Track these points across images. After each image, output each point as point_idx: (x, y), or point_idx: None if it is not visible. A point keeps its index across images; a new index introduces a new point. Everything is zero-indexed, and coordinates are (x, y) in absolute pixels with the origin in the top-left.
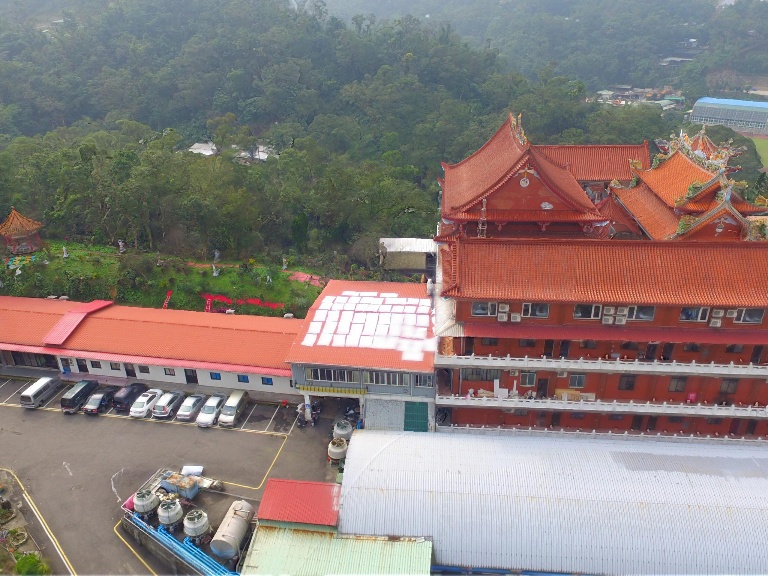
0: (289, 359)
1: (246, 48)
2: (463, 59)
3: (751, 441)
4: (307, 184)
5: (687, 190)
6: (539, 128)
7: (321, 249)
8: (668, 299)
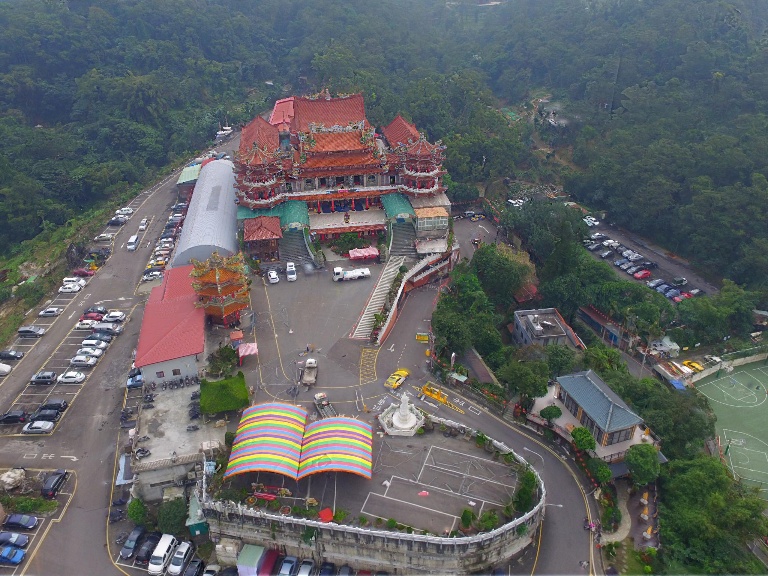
0: None
1: None
2: None
3: None
4: None
5: None
6: (698, 167)
7: None
8: None
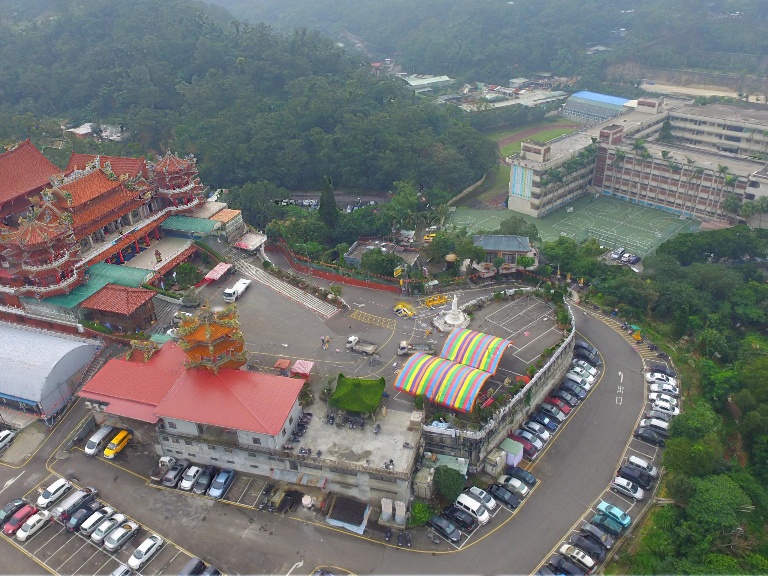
0: None
1: (133, 50)
2: (286, 62)
3: (13, 324)
4: None
5: None
6: (299, 125)
7: None
8: None
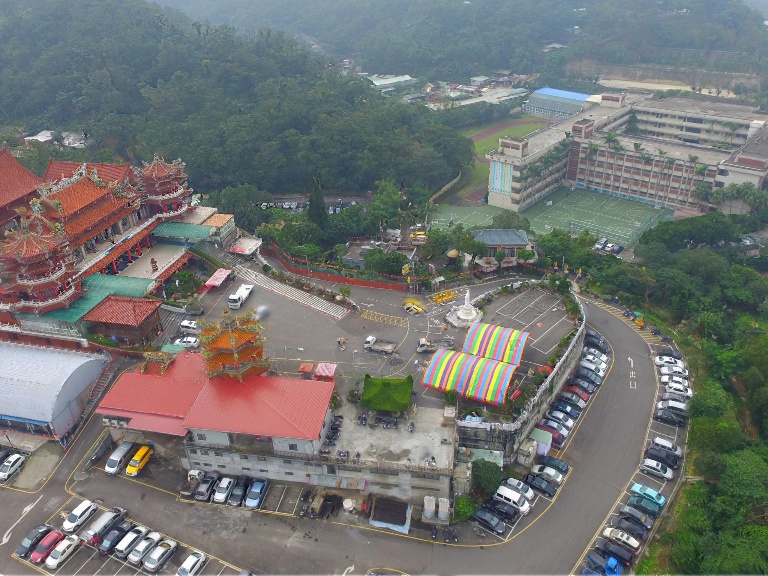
0: None
1: None
2: (254, 64)
3: (6, 343)
4: (41, 172)
5: None
6: (273, 127)
7: None
8: None
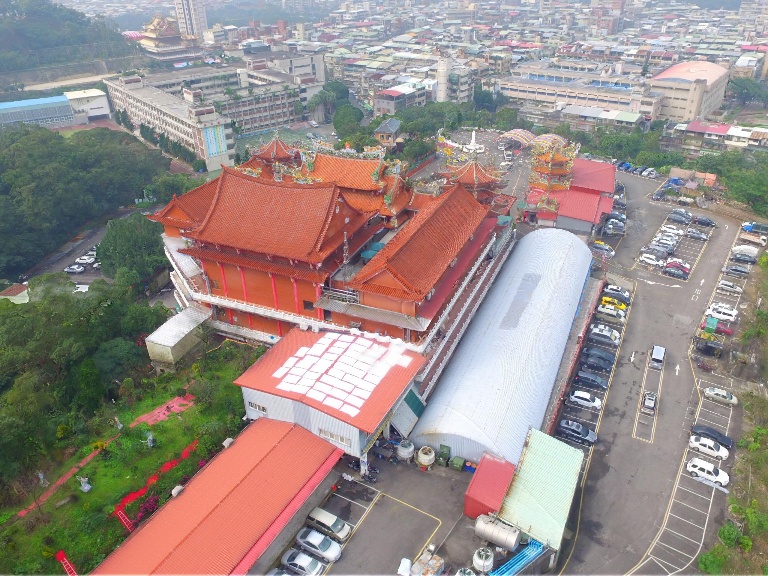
0: (371, 429)
1: None
2: None
3: None
4: None
5: (371, 176)
6: None
7: (65, 400)
8: (467, 235)
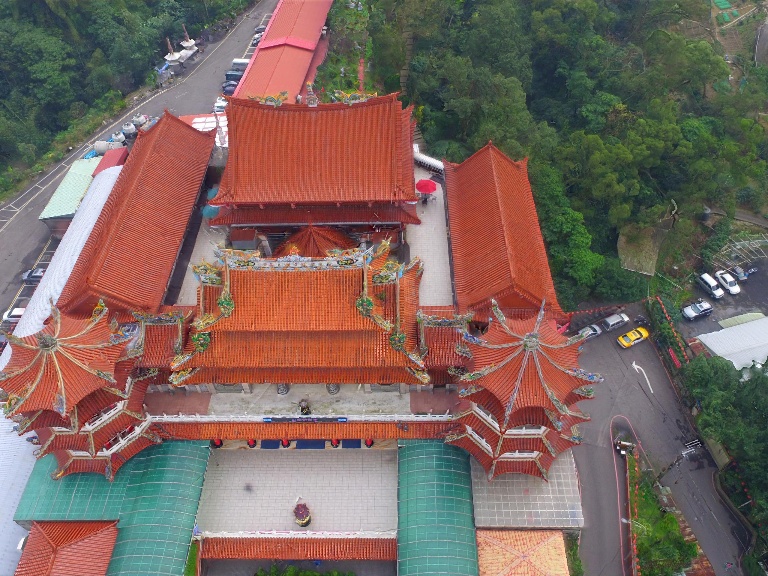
0: (182, 117)
1: None
2: None
3: None
4: None
5: None
6: None
7: None
8: (92, 237)
